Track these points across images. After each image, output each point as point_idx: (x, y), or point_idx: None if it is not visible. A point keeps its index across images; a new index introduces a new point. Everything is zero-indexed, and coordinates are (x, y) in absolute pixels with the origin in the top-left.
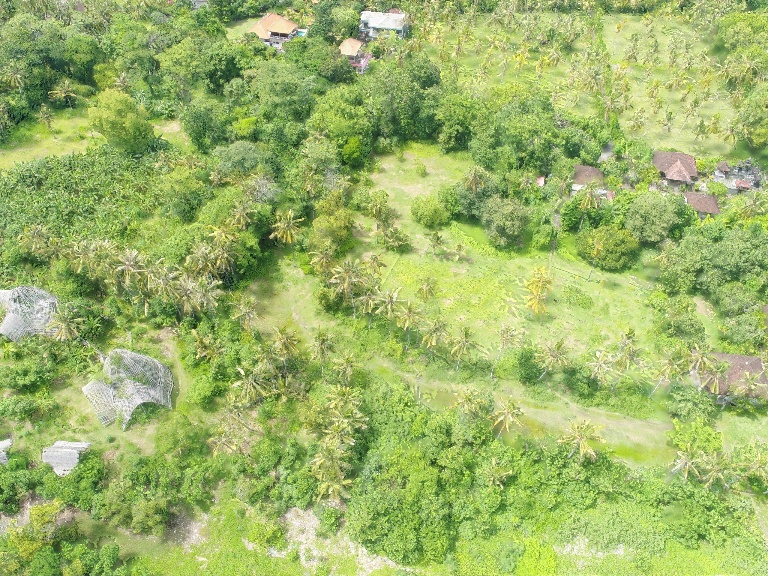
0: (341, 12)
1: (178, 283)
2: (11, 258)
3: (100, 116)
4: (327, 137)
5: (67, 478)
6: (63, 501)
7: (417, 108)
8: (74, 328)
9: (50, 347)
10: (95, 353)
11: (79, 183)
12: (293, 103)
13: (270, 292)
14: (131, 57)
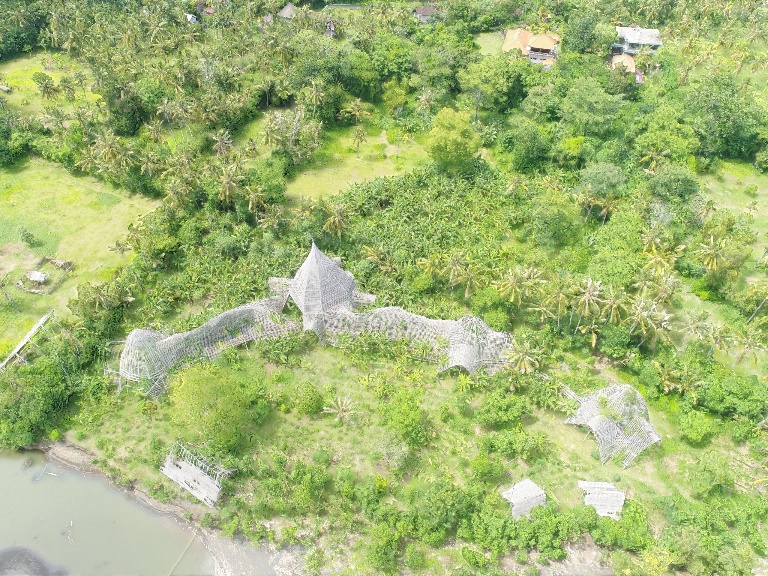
0: (605, 28)
1: (661, 314)
2: (425, 285)
3: (445, 136)
4: (668, 157)
5: (624, 522)
6: (627, 546)
7: (739, 127)
8: (535, 360)
9: (513, 380)
10: (561, 386)
11: (426, 205)
12: (604, 122)
13: (676, 319)
14: (434, 75)
